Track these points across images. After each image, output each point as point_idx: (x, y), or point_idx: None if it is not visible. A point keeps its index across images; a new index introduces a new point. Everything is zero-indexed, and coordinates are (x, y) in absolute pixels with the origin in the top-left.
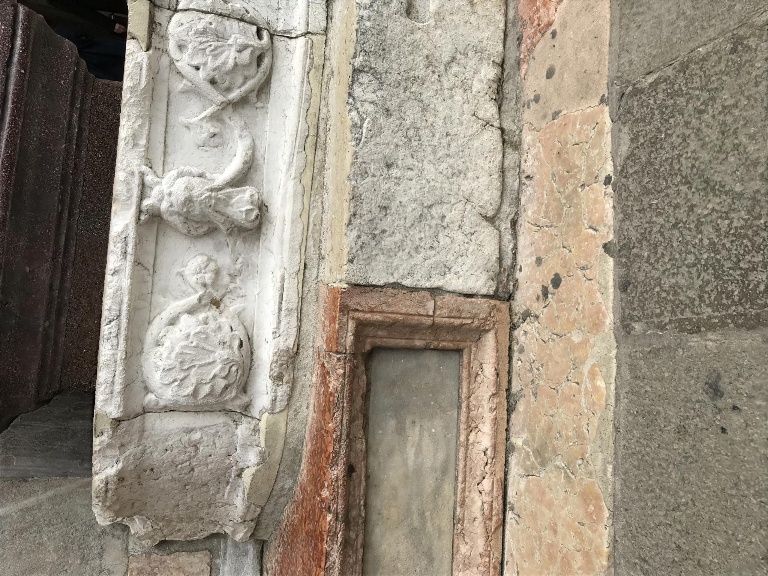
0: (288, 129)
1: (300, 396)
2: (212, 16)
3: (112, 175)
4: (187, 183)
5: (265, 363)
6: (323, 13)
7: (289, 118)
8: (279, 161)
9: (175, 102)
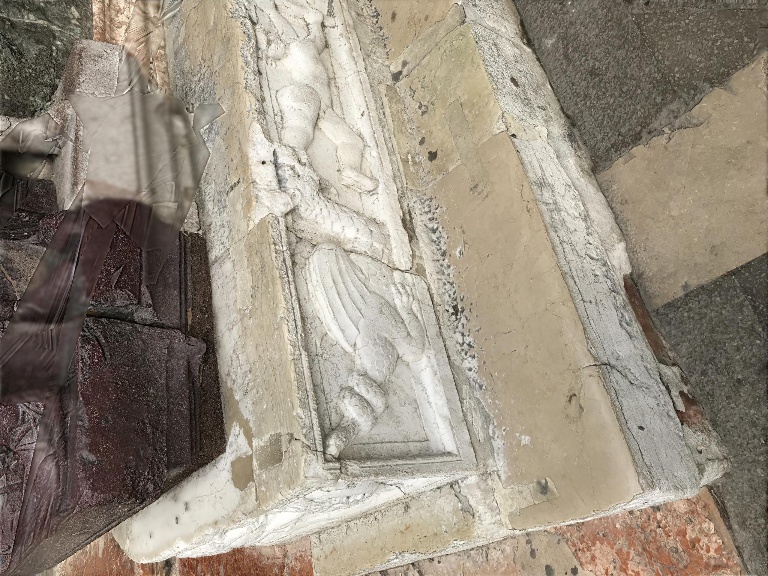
0: None
1: None
2: None
3: None
4: None
5: None
6: None
7: None
8: None
9: None
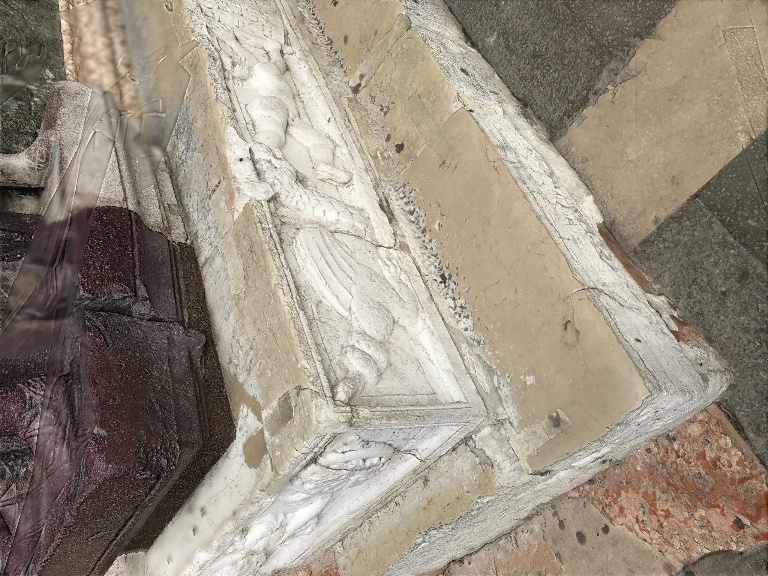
0: (365, 495)
1: (286, 571)
2: (347, 473)
3: (199, 480)
4: (265, 546)
5: (271, 566)
6: (449, 448)
7: (370, 491)
8: (345, 503)
9: (280, 492)
